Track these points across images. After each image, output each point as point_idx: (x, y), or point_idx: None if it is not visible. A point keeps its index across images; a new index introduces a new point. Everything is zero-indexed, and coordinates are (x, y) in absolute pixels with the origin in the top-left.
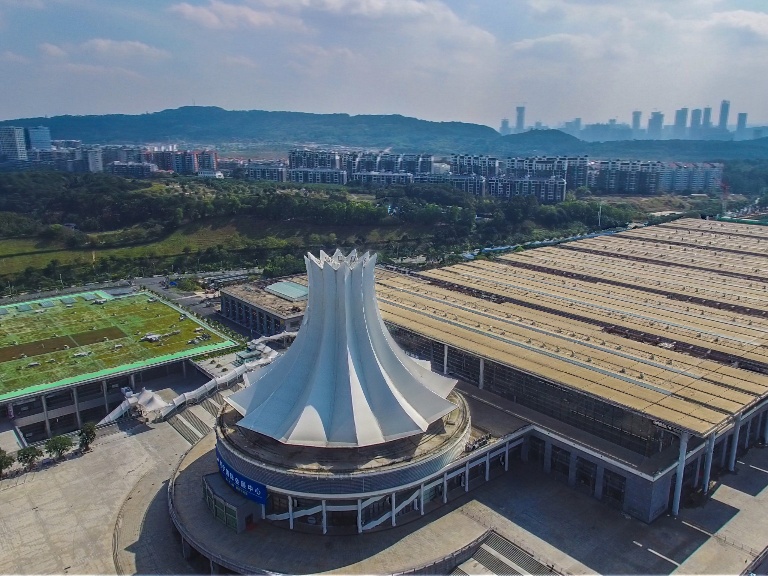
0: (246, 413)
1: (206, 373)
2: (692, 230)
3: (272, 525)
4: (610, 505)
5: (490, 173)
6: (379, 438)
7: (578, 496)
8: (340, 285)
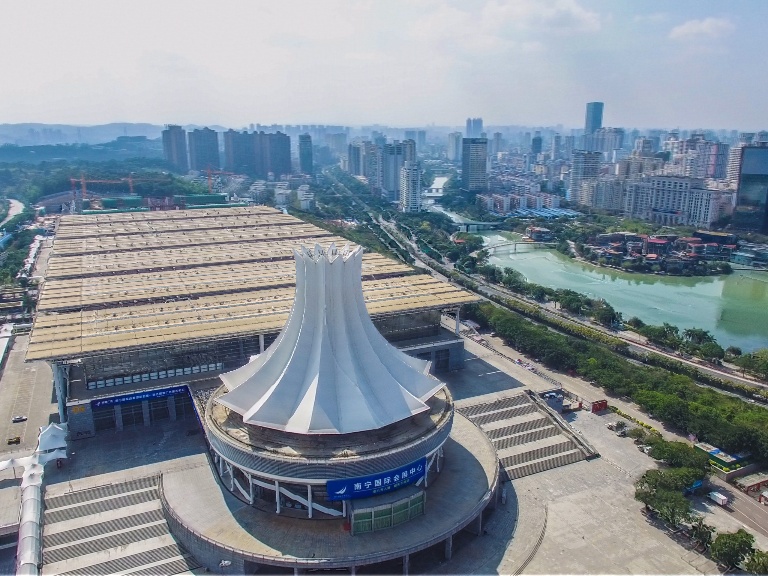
0: (338, 430)
1: None
2: (101, 223)
3: None
4: (443, 372)
5: None
6: None
7: None
8: (356, 272)
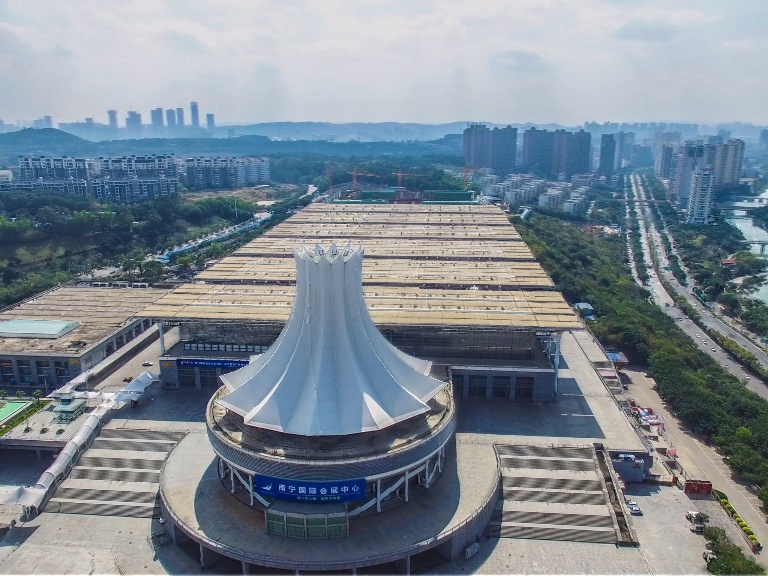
0: (283, 428)
1: (39, 443)
2: (333, 212)
3: (361, 518)
4: (524, 402)
5: (81, 176)
6: (421, 401)
7: (502, 405)
8: (349, 276)
